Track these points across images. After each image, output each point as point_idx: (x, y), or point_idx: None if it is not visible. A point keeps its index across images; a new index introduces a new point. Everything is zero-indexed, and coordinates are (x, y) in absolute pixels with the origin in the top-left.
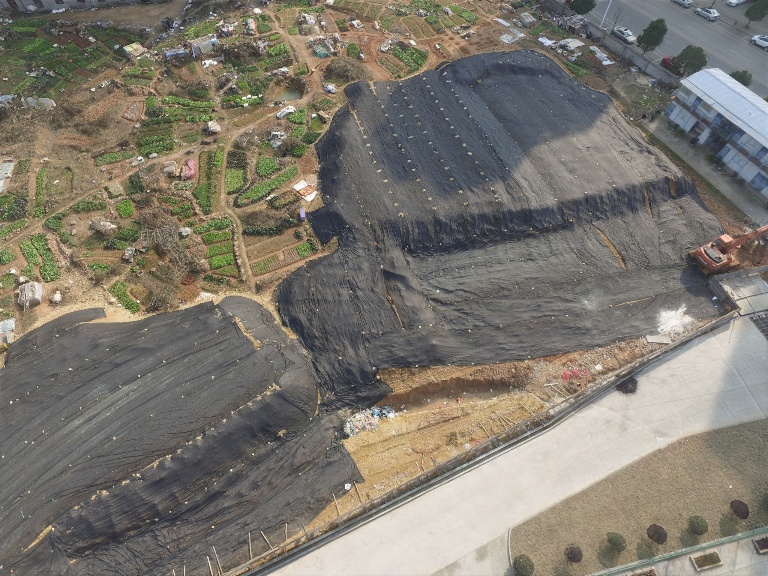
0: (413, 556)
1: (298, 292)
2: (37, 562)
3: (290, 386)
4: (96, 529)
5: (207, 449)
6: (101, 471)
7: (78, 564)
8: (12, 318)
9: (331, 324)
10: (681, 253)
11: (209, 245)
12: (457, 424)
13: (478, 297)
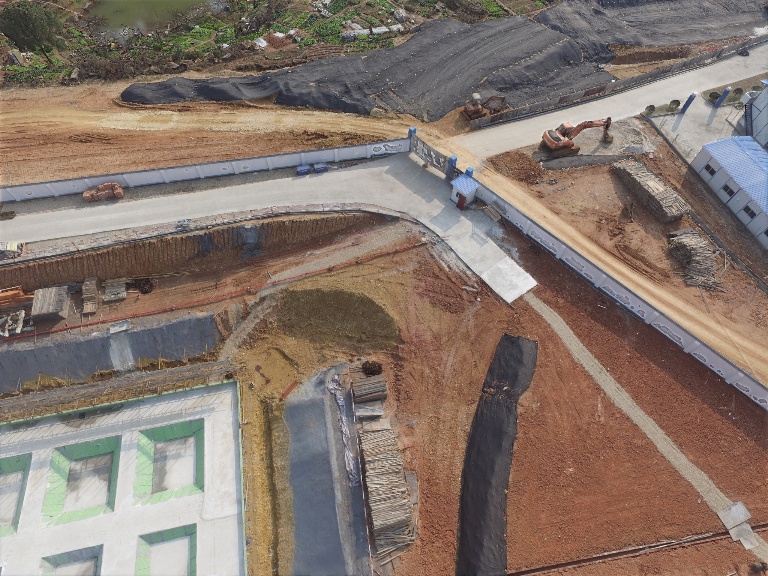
0: (657, 99)
1: (551, 15)
2: (486, 88)
3: (572, 41)
4: (506, 80)
5: (544, 57)
6: (497, 63)
7: (502, 93)
8: (398, 24)
9: (576, 27)
10: (760, 6)
11: (482, 4)
12: (658, 65)
13: (649, 24)
